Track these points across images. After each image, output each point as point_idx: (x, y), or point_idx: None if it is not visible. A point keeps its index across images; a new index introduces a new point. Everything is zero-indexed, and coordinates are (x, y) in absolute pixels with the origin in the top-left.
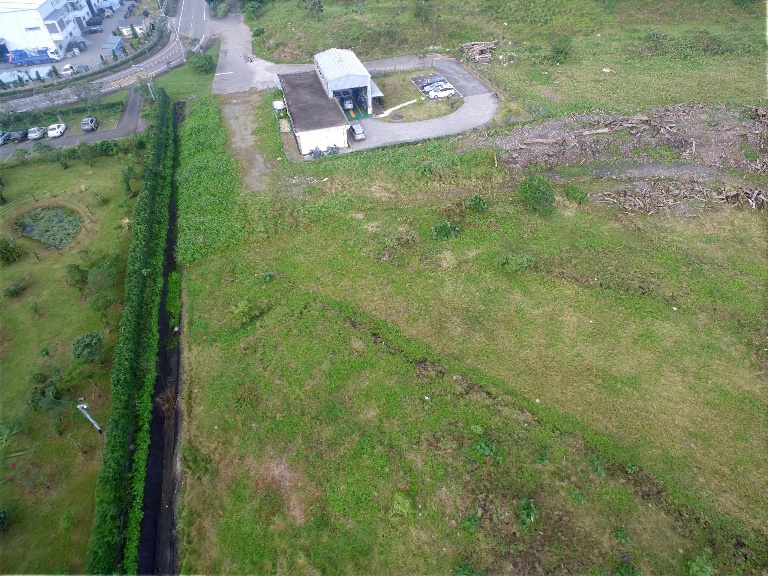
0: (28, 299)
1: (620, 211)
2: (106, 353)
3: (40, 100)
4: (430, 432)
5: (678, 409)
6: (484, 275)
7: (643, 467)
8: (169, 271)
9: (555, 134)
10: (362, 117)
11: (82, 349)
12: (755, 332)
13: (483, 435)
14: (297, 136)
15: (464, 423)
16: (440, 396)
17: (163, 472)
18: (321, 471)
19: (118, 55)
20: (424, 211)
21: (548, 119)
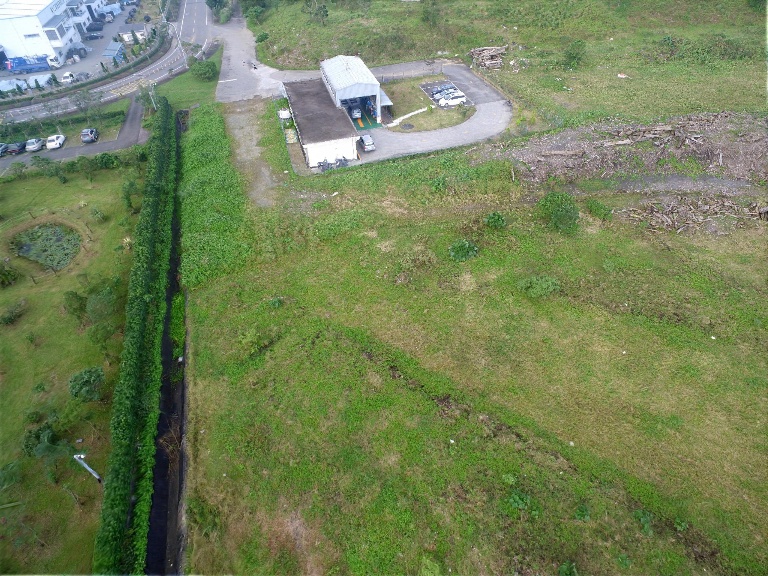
0: (24, 327)
1: (647, 229)
2: (106, 388)
3: (38, 110)
4: (457, 482)
5: (726, 454)
6: (507, 300)
7: (693, 522)
8: (172, 294)
9: (574, 145)
10: (371, 127)
11: (80, 387)
12: None
13: (515, 485)
14: (305, 148)
15: (494, 471)
16: (466, 439)
17: (167, 524)
18: (340, 527)
19: (119, 62)
20: (440, 229)
21: (565, 129)
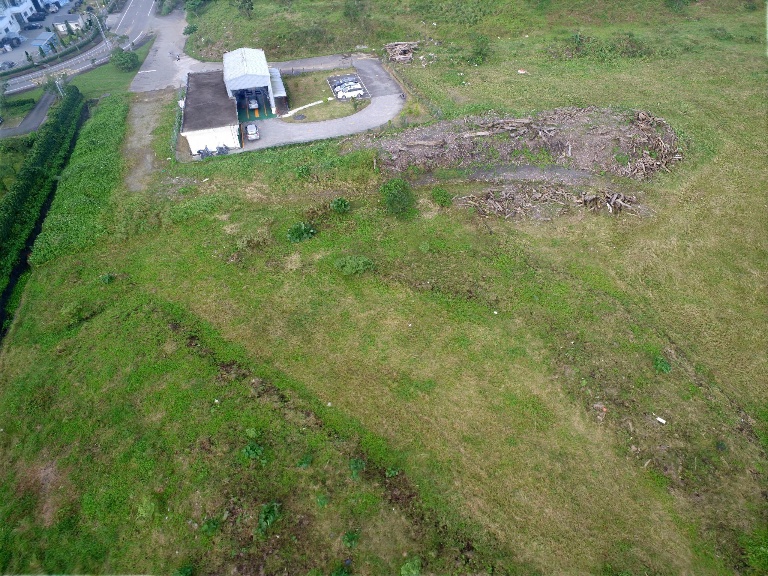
0: None
1: (479, 214)
2: None
3: None
4: (206, 435)
5: (461, 413)
6: (323, 278)
7: (405, 471)
8: (22, 271)
9: (439, 136)
10: (265, 117)
11: None
12: (562, 337)
13: (258, 438)
14: None
15: (244, 426)
16: (230, 399)
17: None
18: (86, 474)
19: (46, 52)
20: (289, 213)
21: (440, 121)
